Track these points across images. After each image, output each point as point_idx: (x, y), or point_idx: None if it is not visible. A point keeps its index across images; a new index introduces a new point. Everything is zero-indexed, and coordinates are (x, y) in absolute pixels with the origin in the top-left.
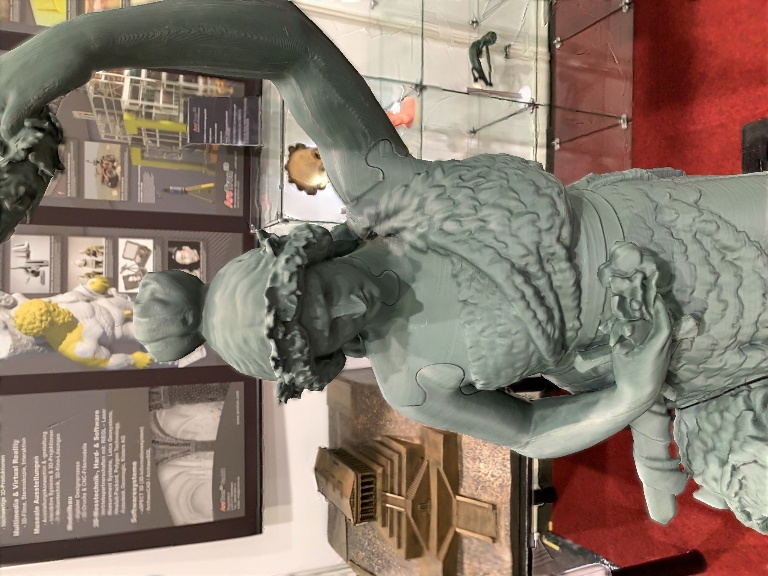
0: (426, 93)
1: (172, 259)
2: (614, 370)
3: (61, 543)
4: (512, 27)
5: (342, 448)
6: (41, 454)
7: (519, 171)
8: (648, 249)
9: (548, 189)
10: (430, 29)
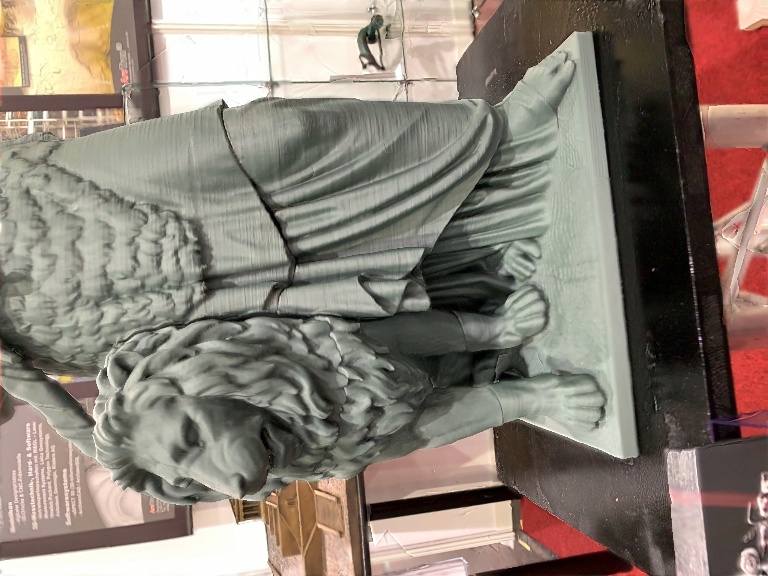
0: (280, 89)
1: None
2: None
3: (7, 544)
4: (426, 5)
5: None
6: None
7: None
8: None
9: None
10: (276, 25)
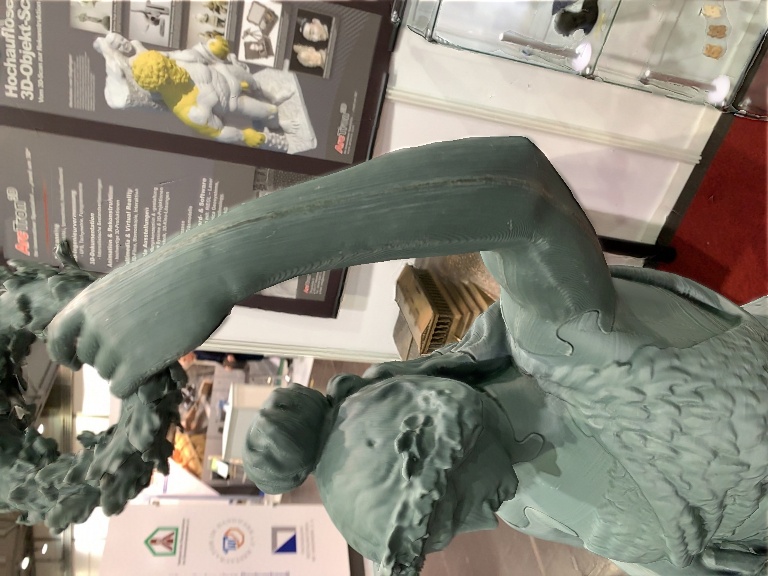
0: None
1: (299, 32)
2: None
3: None
4: None
5: (428, 271)
6: (151, 207)
7: (753, 400)
8: None
9: None
10: None
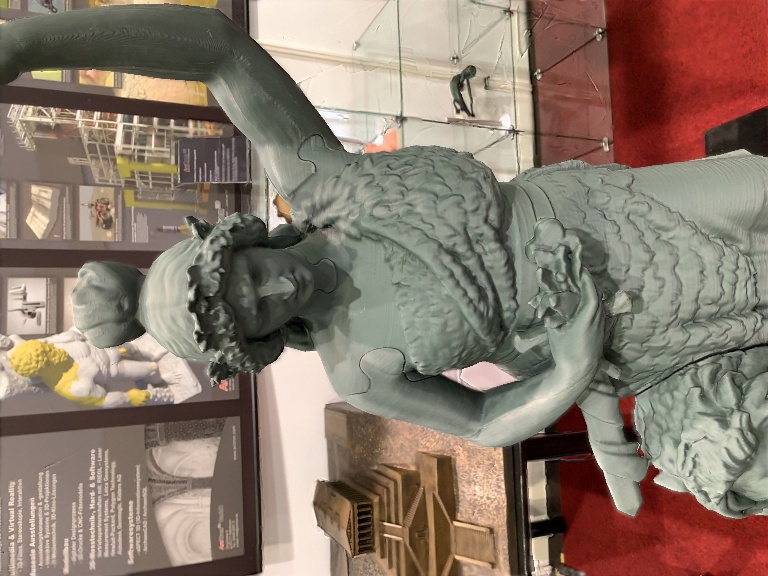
0: (407, 124)
1: None
2: (550, 347)
3: None
4: (493, 62)
5: (340, 480)
6: (37, 495)
7: (445, 158)
8: (580, 230)
9: (474, 173)
10: (408, 64)
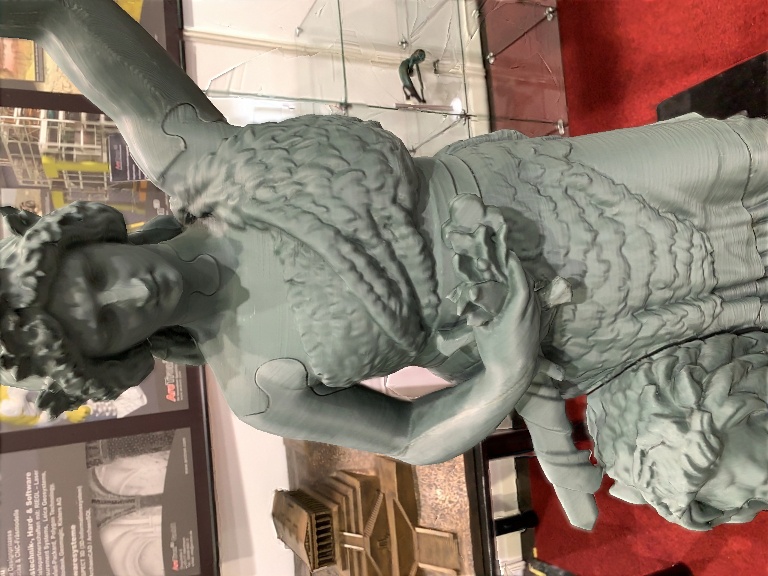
0: (352, 111)
1: None
2: (478, 348)
3: None
4: (444, 46)
5: (300, 489)
6: None
7: (342, 127)
8: (510, 208)
9: (377, 144)
10: (350, 47)
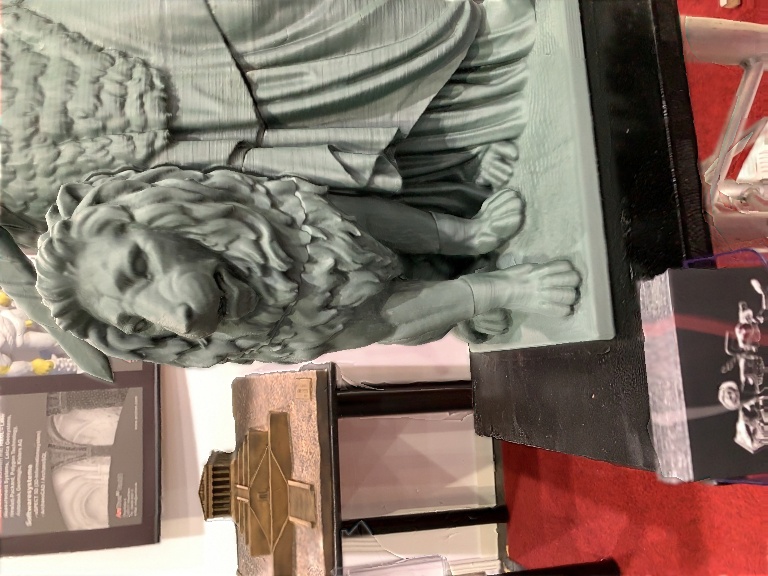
0: None
1: None
2: None
3: None
4: None
5: None
6: None
7: None
8: None
9: None
10: None
